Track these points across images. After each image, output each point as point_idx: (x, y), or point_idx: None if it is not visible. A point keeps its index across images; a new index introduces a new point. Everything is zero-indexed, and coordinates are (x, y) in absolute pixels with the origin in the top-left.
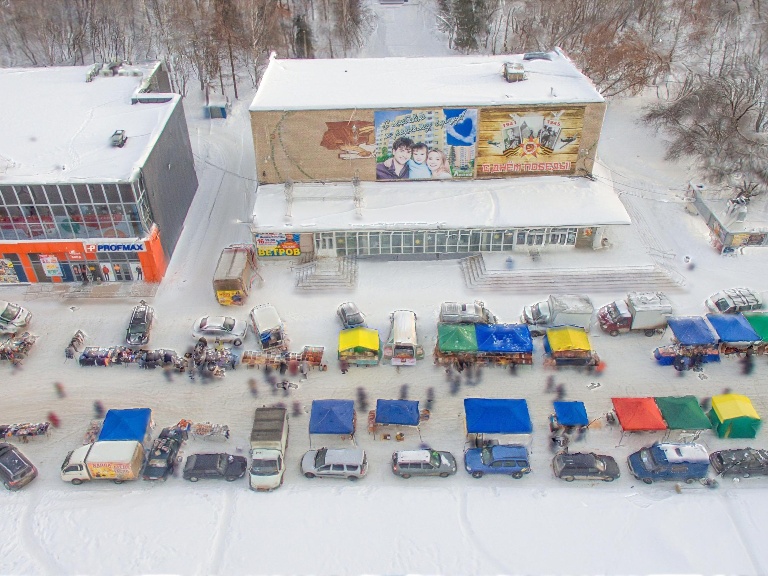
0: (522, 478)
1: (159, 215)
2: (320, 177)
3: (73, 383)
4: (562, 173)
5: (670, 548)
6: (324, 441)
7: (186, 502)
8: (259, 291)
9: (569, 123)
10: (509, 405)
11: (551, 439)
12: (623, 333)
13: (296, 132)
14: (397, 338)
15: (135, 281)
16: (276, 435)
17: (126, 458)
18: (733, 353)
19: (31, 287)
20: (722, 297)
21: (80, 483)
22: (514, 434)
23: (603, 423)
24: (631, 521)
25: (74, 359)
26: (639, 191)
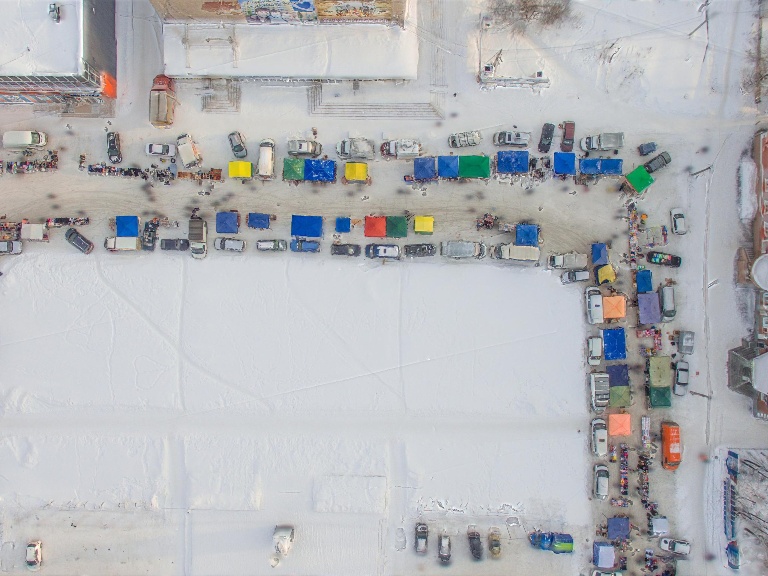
0: (317, 253)
1: (101, 66)
2: (206, 21)
3: (90, 188)
4: (383, 23)
5: (368, 291)
6: (224, 234)
7: (166, 263)
8: (179, 114)
9: (381, 5)
10: (313, 222)
11: (332, 236)
12: (393, 159)
13: (181, 4)
14: (260, 172)
15: (99, 104)
16: (200, 237)
17: (133, 247)
18: (447, 179)
19: (35, 106)
20: (456, 140)
21: (115, 250)
22: (313, 237)
23: (363, 223)
24: (357, 278)
25: (85, 172)
26: (433, 43)
